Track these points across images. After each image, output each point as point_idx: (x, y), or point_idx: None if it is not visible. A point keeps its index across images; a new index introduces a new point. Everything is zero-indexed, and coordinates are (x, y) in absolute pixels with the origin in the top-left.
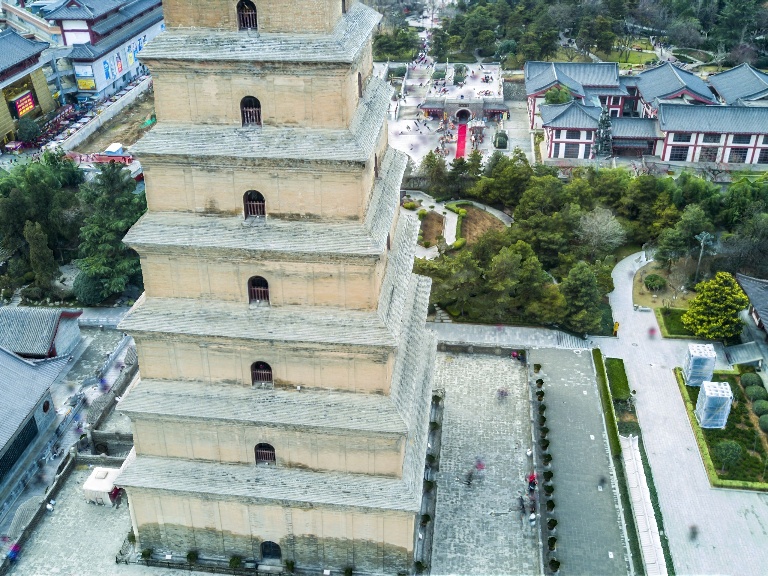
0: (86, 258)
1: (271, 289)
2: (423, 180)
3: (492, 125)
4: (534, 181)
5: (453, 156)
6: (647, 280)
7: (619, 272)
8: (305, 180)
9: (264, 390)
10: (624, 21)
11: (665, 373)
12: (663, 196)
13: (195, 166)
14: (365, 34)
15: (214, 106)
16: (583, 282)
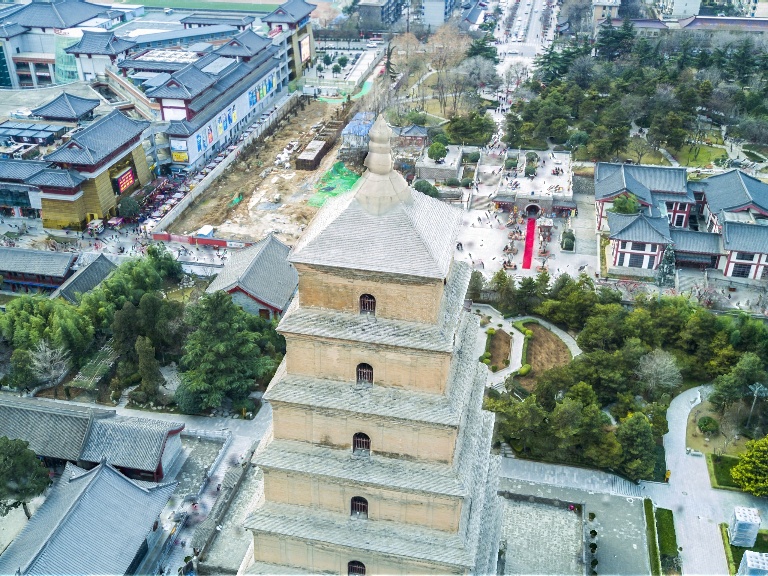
0: (188, 372)
1: (370, 507)
2: (493, 295)
3: (560, 221)
4: (598, 309)
5: (521, 256)
6: (701, 423)
7: (674, 409)
8: (406, 431)
9: None
10: (695, 118)
11: (712, 528)
12: (721, 335)
13: (316, 411)
14: (461, 302)
15: (335, 367)
16: (639, 432)
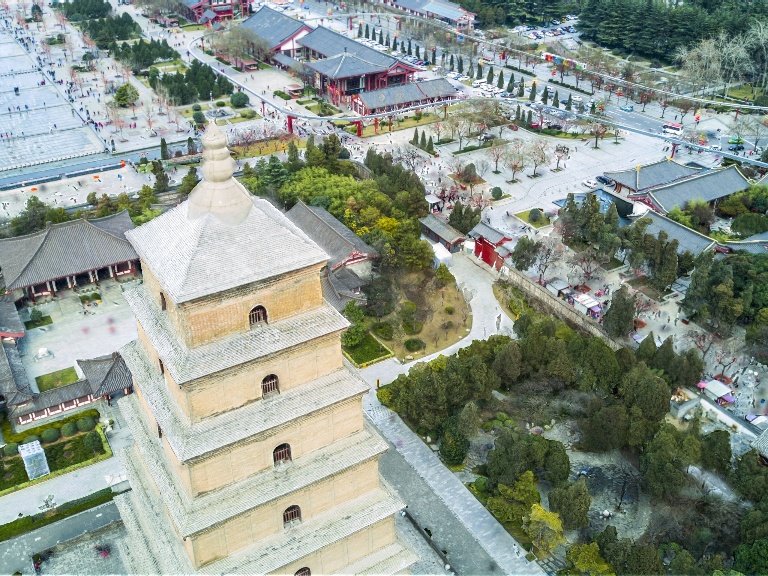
0: None
1: None
2: None
3: None
4: None
5: None
6: None
7: None
8: None
9: None
10: None
11: None
12: None
13: None
14: None
15: None
16: None
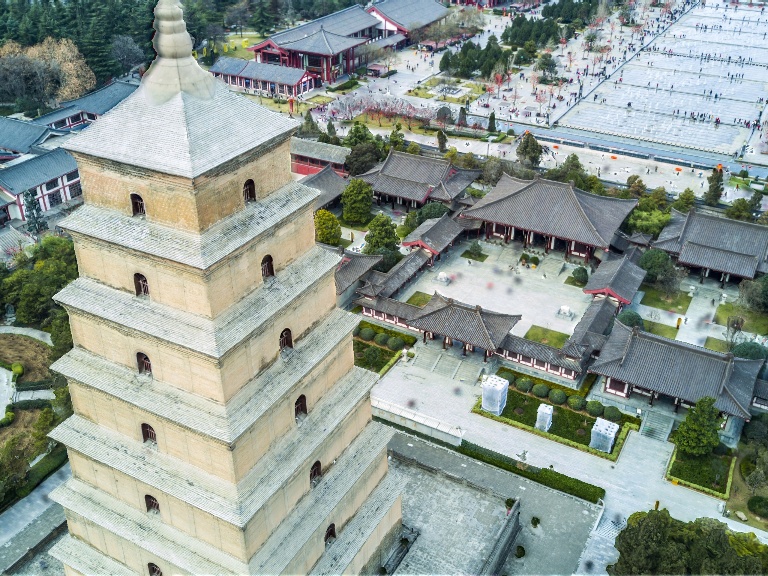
0: None
1: (307, 400)
2: None
3: None
4: (11, 282)
5: None
6: None
7: None
8: (310, 298)
9: (319, 485)
10: None
11: None
12: None
13: None
14: None
15: (247, 279)
16: None
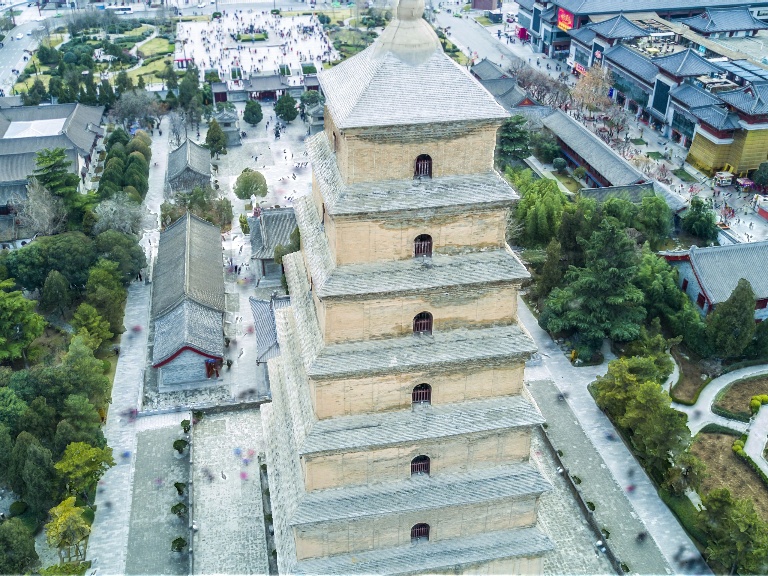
0: (563, 291)
1: None
2: None
3: None
4: None
5: None
6: None
7: None
8: None
9: None
10: None
11: None
12: None
13: None
14: (430, 204)
15: None
16: None
